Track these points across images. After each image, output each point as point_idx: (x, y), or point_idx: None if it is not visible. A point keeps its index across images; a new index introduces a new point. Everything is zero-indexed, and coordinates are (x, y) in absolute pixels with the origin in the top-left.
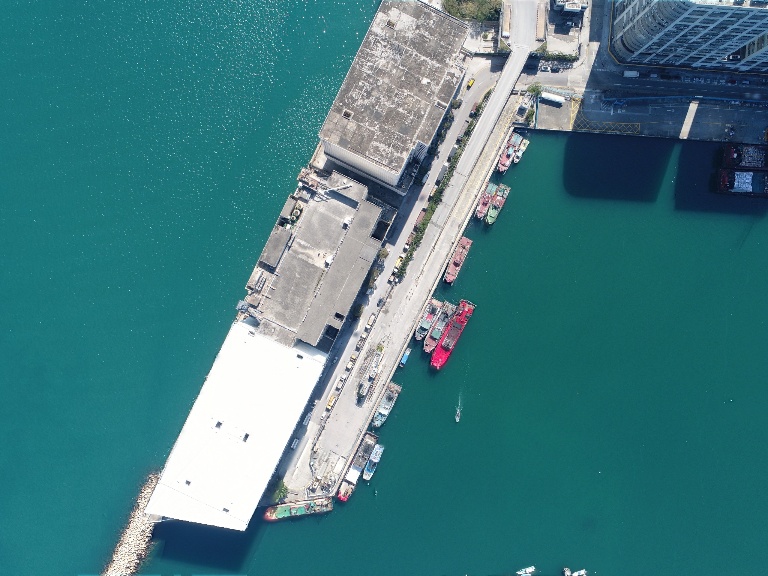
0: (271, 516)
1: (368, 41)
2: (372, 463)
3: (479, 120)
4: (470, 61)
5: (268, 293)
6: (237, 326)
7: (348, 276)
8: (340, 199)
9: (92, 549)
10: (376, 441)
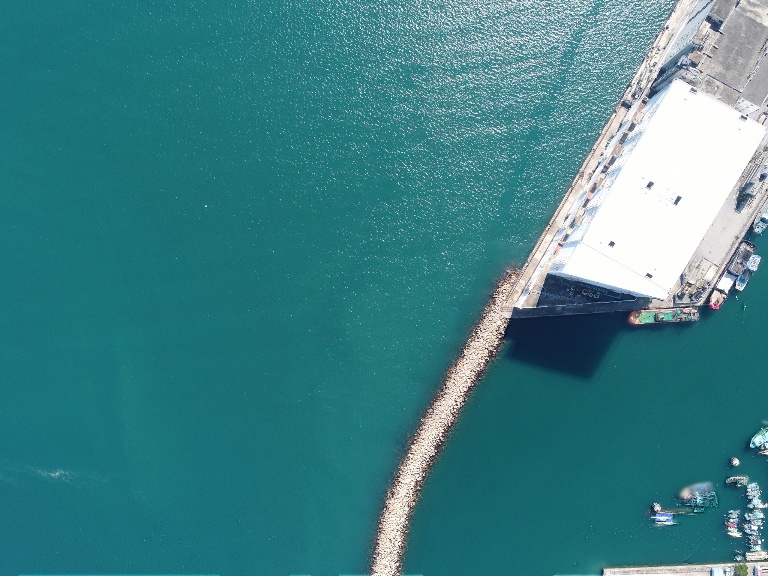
0: (634, 321)
1: None
2: (748, 272)
3: None
4: None
5: (709, 52)
6: (678, 82)
7: None
8: None
9: (441, 343)
10: (753, 250)
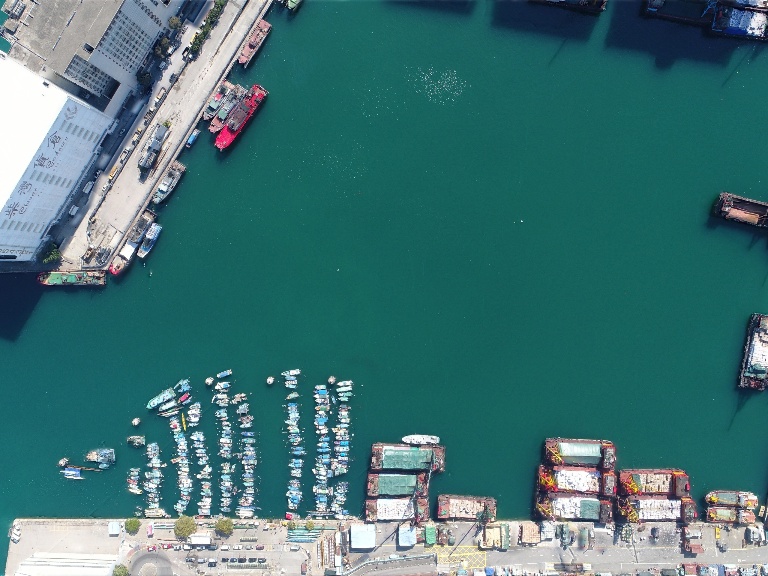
0: (43, 281)
1: None
2: (147, 240)
3: None
4: None
5: (26, 21)
6: None
7: (102, 8)
8: None
9: None
10: (154, 219)
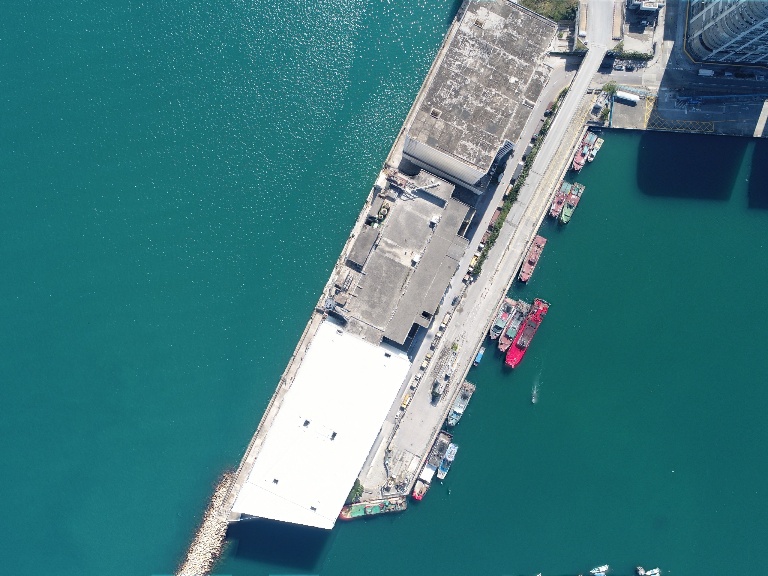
0: (346, 515)
1: (456, 40)
2: (447, 462)
3: (555, 119)
4: (546, 60)
5: (355, 292)
6: (325, 325)
7: (435, 275)
8: (427, 198)
9: (166, 548)
10: (450, 440)
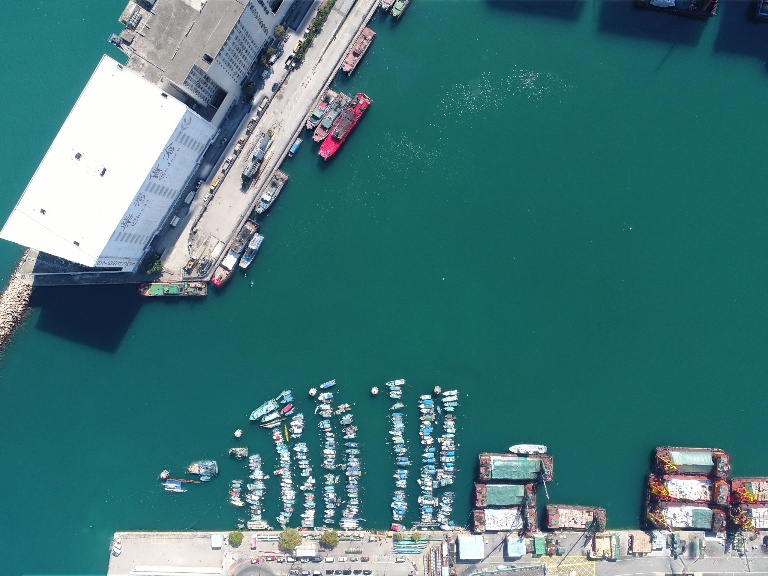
0: (144, 293)
1: None
2: (249, 250)
3: None
4: None
5: (143, 31)
6: (107, 59)
7: (221, 18)
8: None
9: None
10: (256, 229)
